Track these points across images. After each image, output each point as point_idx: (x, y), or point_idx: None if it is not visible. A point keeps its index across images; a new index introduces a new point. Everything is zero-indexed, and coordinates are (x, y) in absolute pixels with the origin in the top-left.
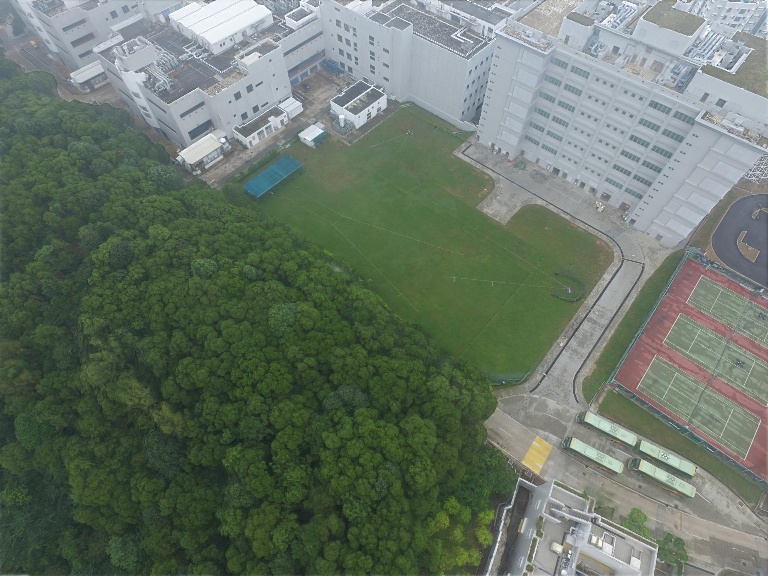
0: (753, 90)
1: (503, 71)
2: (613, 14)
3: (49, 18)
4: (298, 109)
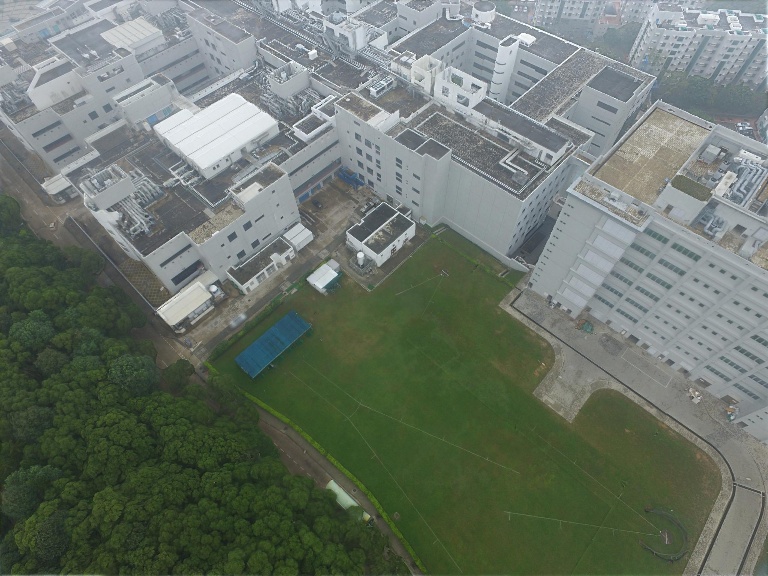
0: None
1: (573, 230)
2: (730, 172)
3: (15, 125)
4: (307, 239)
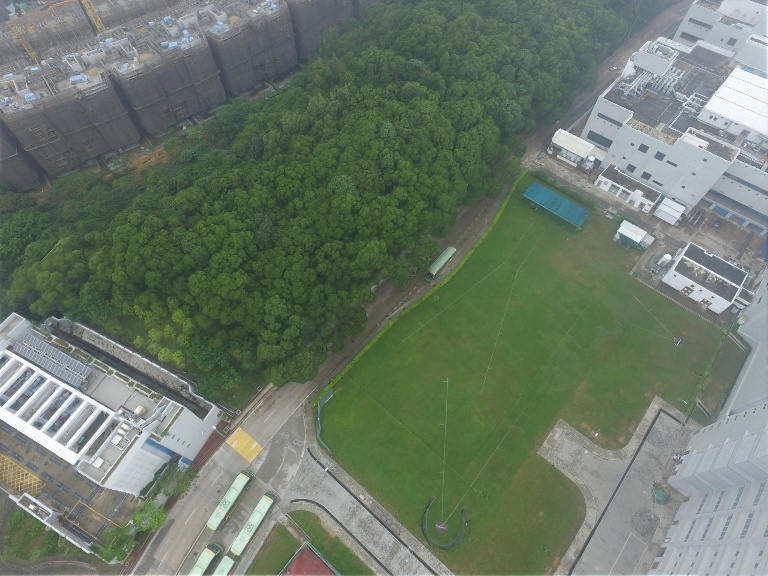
0: None
1: None
2: None
3: None
4: (670, 218)
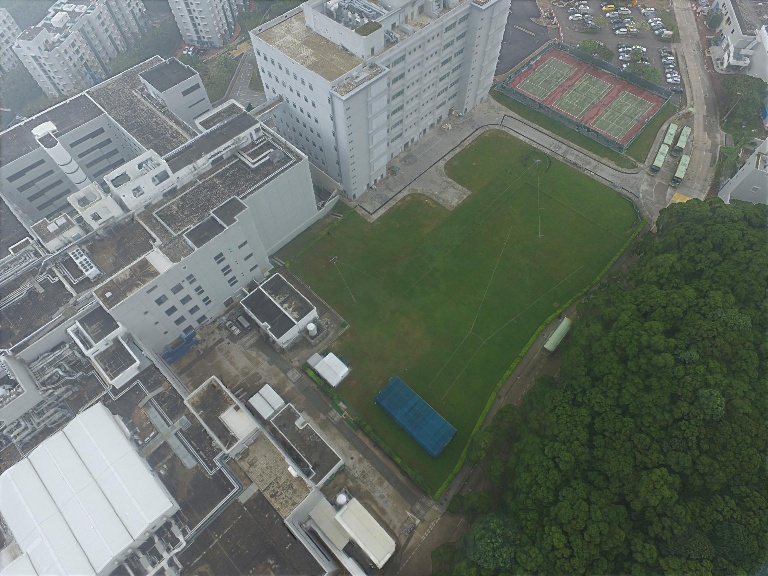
0: None
1: (357, 123)
2: None
3: None
4: None
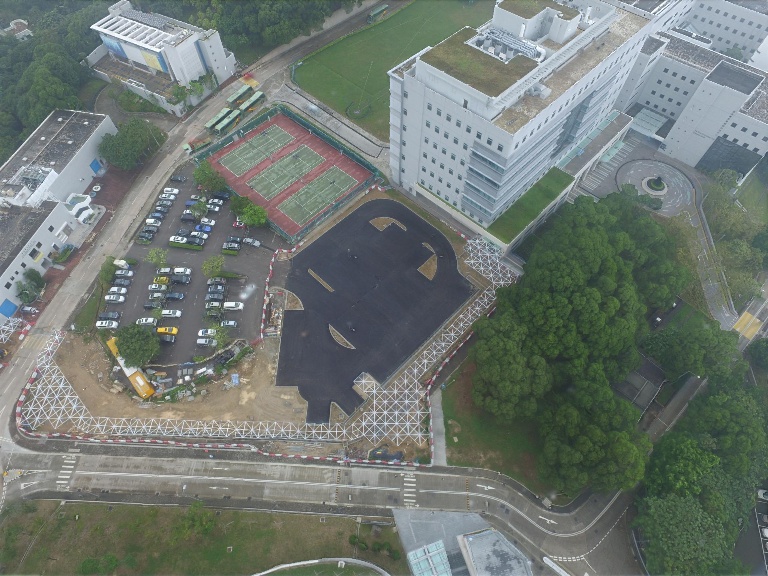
0: (440, 45)
1: None
2: None
3: None
4: None
